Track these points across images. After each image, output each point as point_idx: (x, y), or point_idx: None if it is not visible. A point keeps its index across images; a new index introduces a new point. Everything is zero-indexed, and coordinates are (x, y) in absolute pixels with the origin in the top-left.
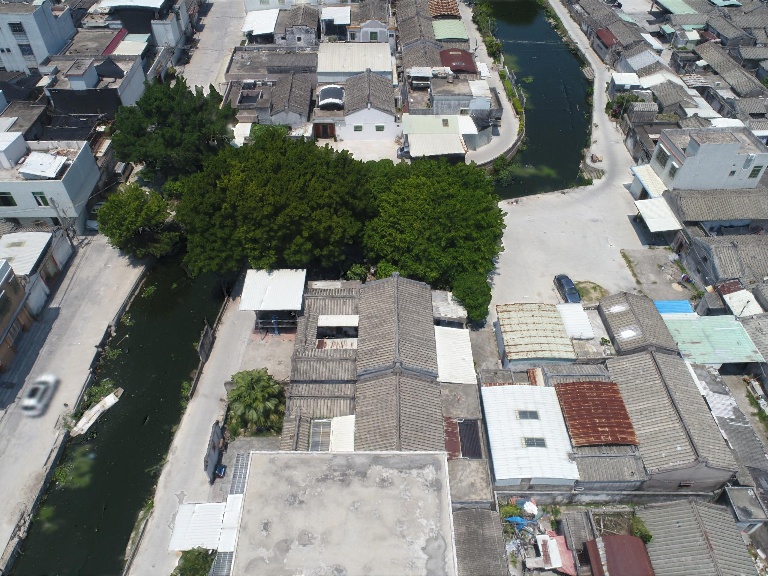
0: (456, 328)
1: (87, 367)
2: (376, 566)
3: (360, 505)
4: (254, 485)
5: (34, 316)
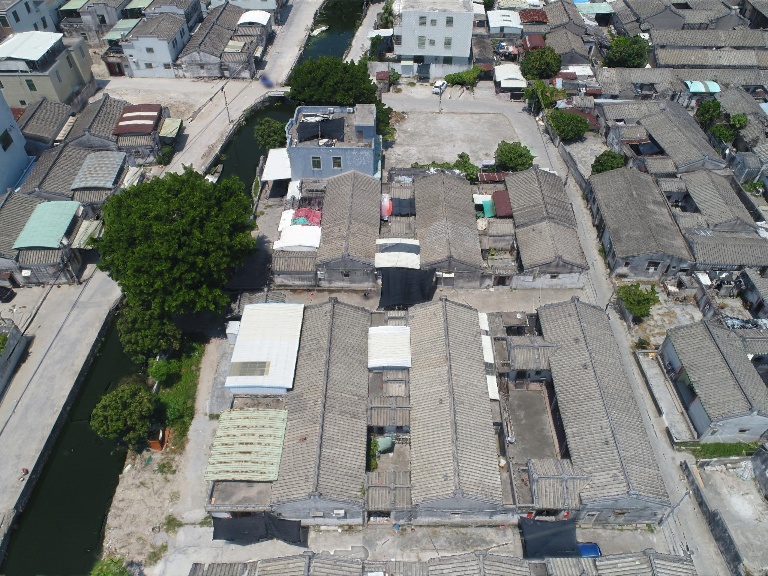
0: (478, 4)
1: (312, 18)
2: (447, 2)
3: None
4: None
5: (283, 4)
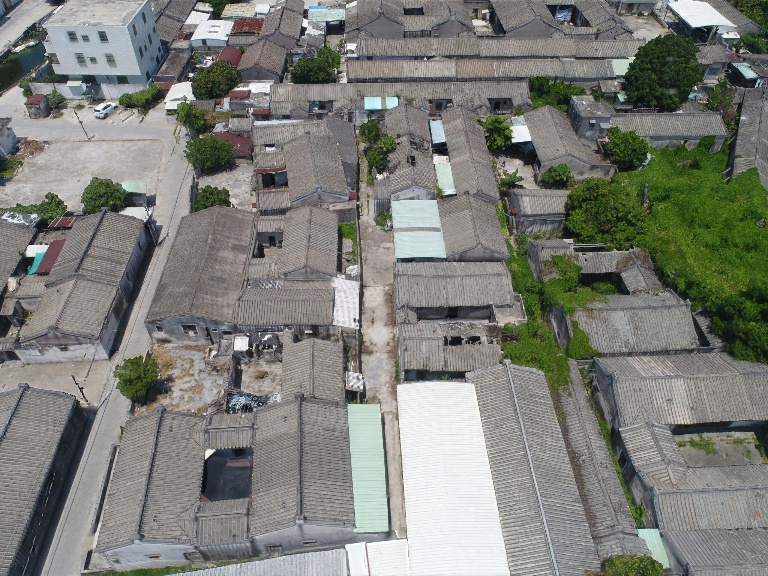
0: (204, 13)
1: (22, 32)
2: None
3: (109, 6)
4: (70, 3)
5: None
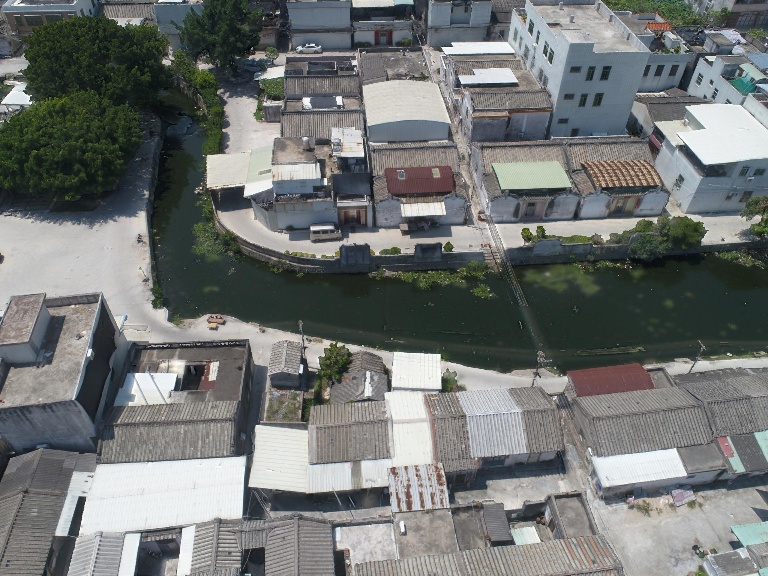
0: None
1: None
2: None
3: None
4: None
5: None
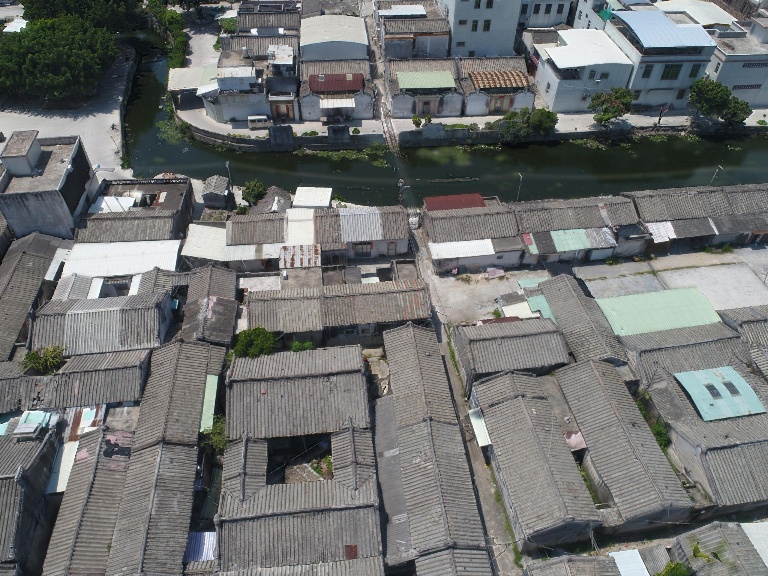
0: None
1: None
2: None
3: None
4: None
5: None
